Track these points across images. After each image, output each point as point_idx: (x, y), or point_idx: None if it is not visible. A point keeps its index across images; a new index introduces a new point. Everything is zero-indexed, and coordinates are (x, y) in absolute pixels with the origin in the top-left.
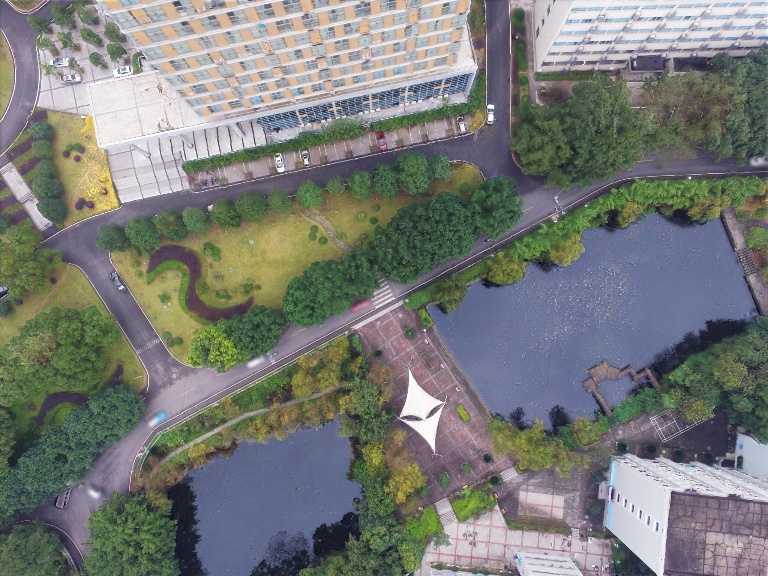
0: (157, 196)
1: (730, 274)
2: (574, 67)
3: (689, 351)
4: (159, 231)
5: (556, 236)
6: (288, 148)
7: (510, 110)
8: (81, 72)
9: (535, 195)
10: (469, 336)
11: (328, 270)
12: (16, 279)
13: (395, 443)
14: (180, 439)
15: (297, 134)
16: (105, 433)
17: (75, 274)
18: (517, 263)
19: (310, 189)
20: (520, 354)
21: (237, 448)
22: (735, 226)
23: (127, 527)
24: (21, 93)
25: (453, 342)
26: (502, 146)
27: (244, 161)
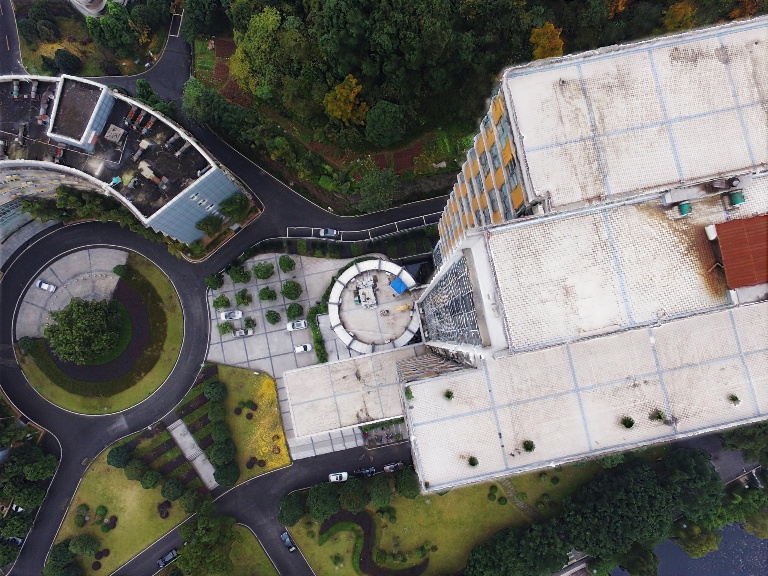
0: (330, 453)
1: None
2: None
3: None
4: (344, 508)
5: (752, 508)
6: None
7: None
8: None
9: (722, 455)
10: None
11: (518, 546)
12: (202, 569)
13: None
14: None
15: None
16: None
17: (244, 534)
18: None
19: None
20: None
21: None
22: None
23: None
24: (190, 346)
25: None
26: None
27: None
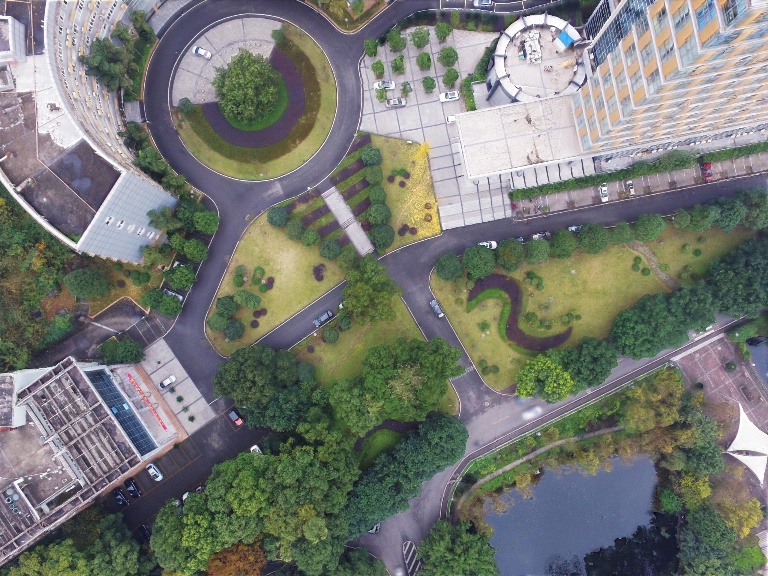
0: (479, 223)
1: None
2: None
3: None
4: (503, 262)
5: None
6: (617, 178)
7: None
8: (405, 96)
9: None
10: None
11: (668, 304)
12: (371, 309)
13: (735, 478)
14: (493, 467)
15: (626, 164)
16: (442, 463)
17: (395, 301)
18: None
19: (662, 223)
20: None
21: (542, 476)
22: None
23: (470, 557)
24: (343, 116)
25: None
26: None
27: (569, 190)
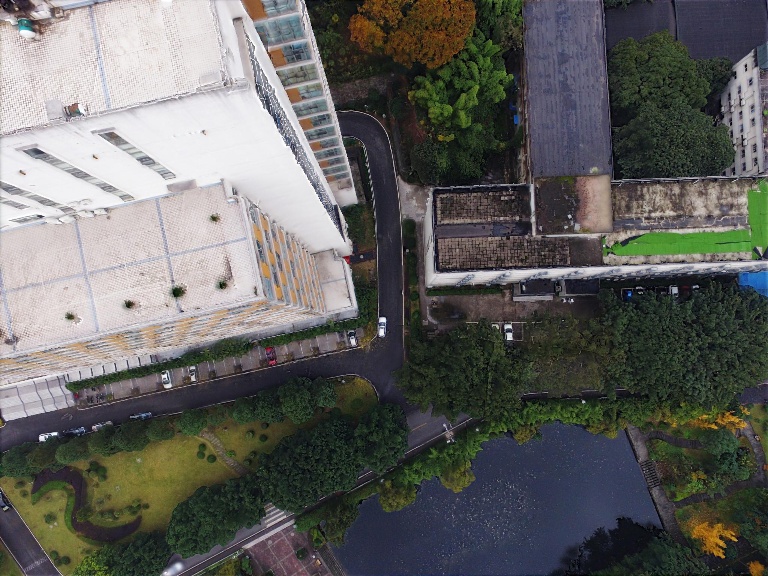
0: (42, 414)
1: (633, 486)
2: (465, 283)
3: (590, 567)
4: None
5: (446, 462)
6: (173, 367)
7: (403, 322)
8: None
9: (429, 411)
10: (364, 553)
11: (211, 501)
12: None
13: None
14: None
15: (183, 352)
16: None
17: None
18: (405, 493)
19: (188, 425)
20: (416, 572)
21: None
22: (638, 437)
23: None
24: None
25: (347, 559)
26: (395, 359)
27: (130, 378)
